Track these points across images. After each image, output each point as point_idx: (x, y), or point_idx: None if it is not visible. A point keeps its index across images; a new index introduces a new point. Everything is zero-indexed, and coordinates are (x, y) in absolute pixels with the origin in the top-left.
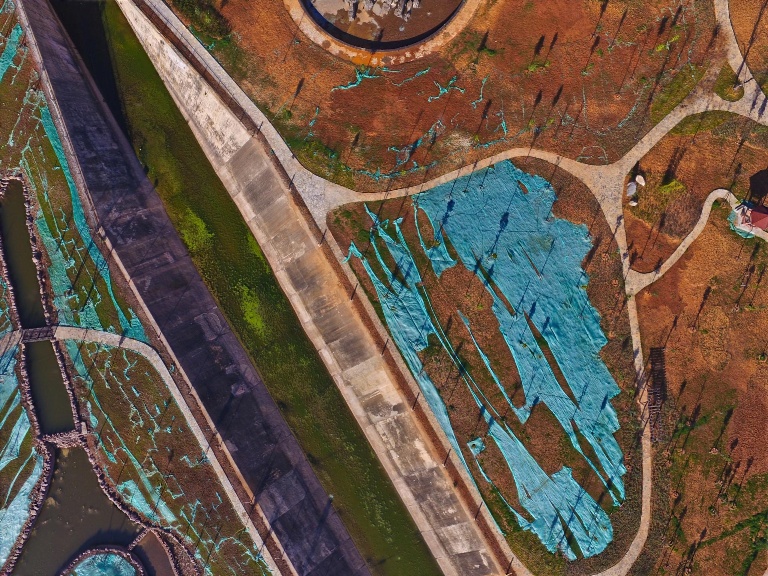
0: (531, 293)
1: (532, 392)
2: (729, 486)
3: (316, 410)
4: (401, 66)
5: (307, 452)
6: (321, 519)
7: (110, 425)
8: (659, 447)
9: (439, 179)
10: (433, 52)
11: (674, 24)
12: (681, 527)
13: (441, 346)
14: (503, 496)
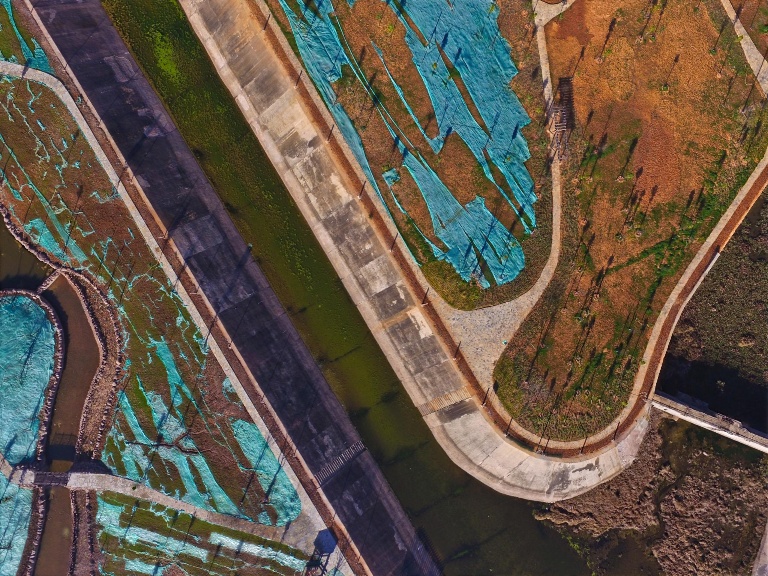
0: (443, 24)
1: (445, 123)
2: (635, 214)
3: (233, 158)
4: None
5: (225, 201)
6: (239, 264)
7: (15, 160)
8: (568, 175)
9: None
10: None
11: None
12: (590, 254)
13: (355, 77)
14: (418, 227)
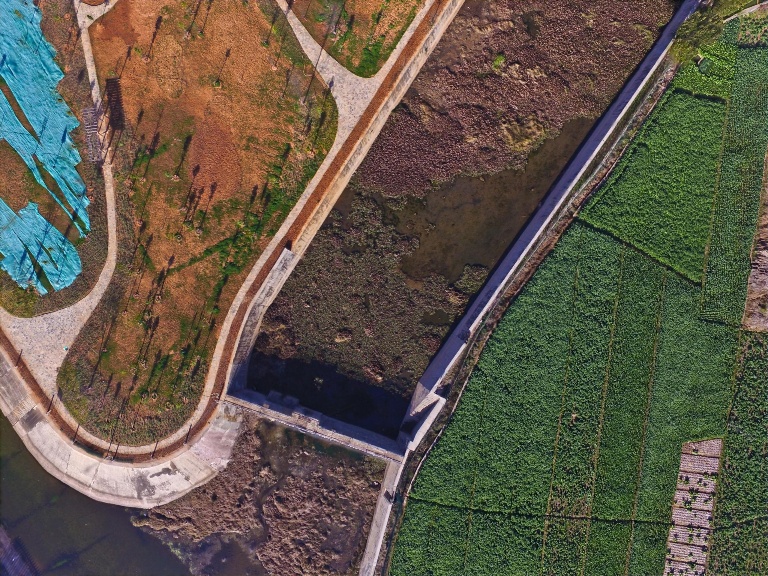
0: None
1: None
2: (194, 213)
3: None
4: None
5: None
6: None
7: None
8: (120, 177)
9: None
10: None
11: None
12: (148, 255)
13: None
14: None
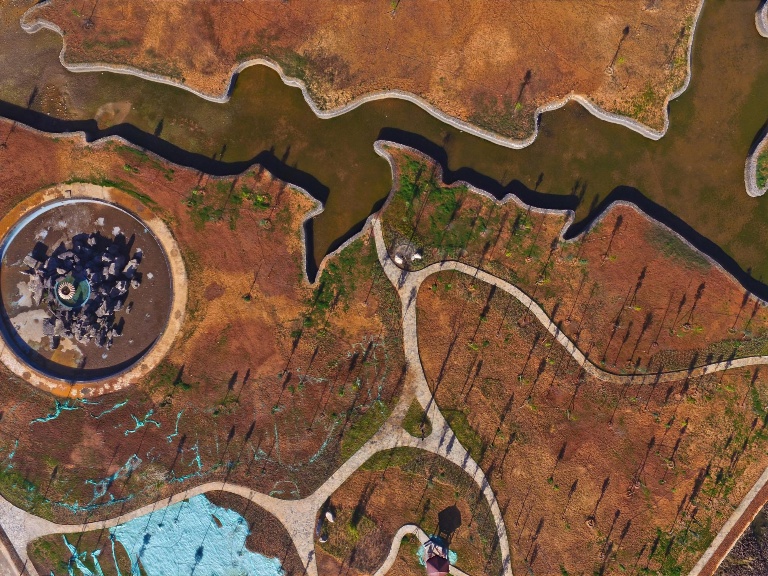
0: None
1: None
2: None
3: None
4: (100, 398)
5: None
6: None
7: None
8: None
9: (135, 512)
10: (131, 384)
11: (365, 360)
12: None
13: None
14: None
